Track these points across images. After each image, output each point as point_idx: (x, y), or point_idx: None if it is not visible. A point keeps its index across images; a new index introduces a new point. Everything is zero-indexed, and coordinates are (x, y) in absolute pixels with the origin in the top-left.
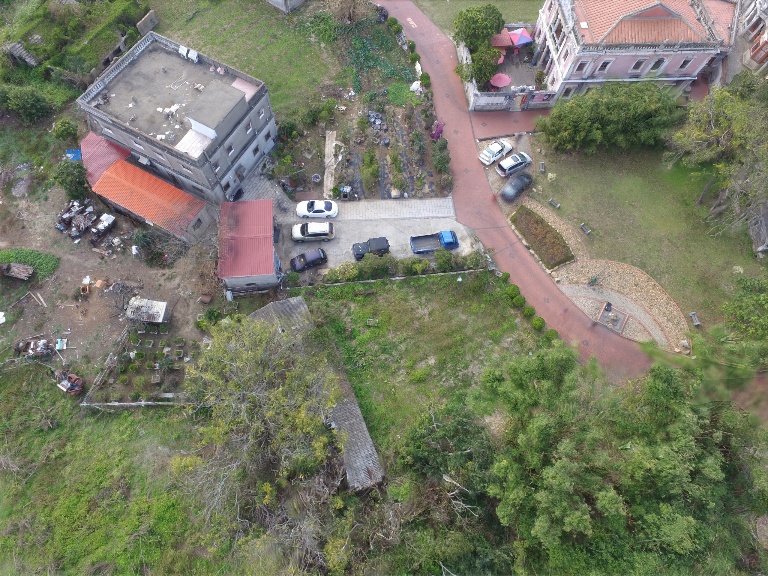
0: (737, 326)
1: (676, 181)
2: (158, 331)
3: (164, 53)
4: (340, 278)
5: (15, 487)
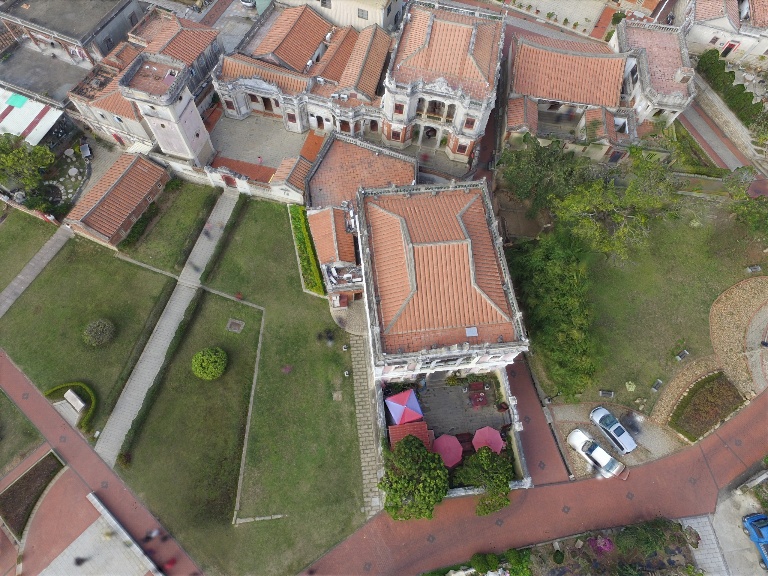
0: None
1: None
2: None
3: None
4: None
5: None
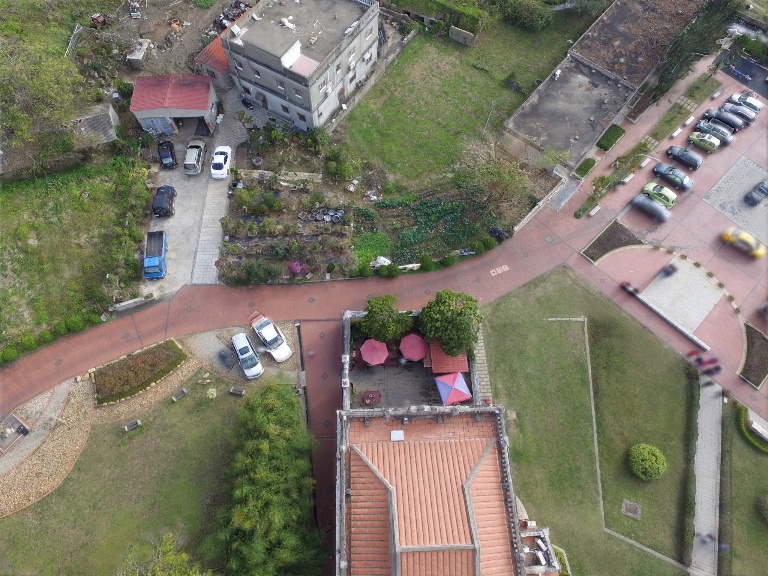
0: None
1: None
2: None
3: (359, 16)
4: None
5: (38, 4)
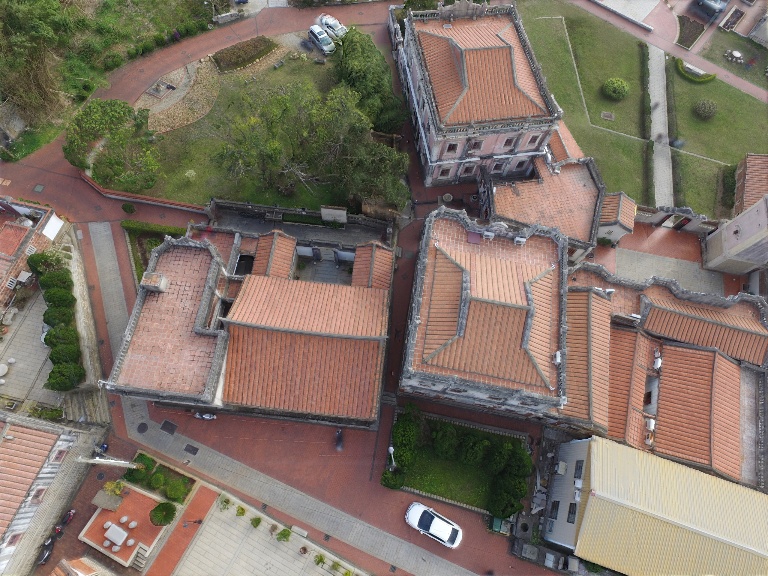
0: None
1: None
2: None
3: None
4: None
5: None
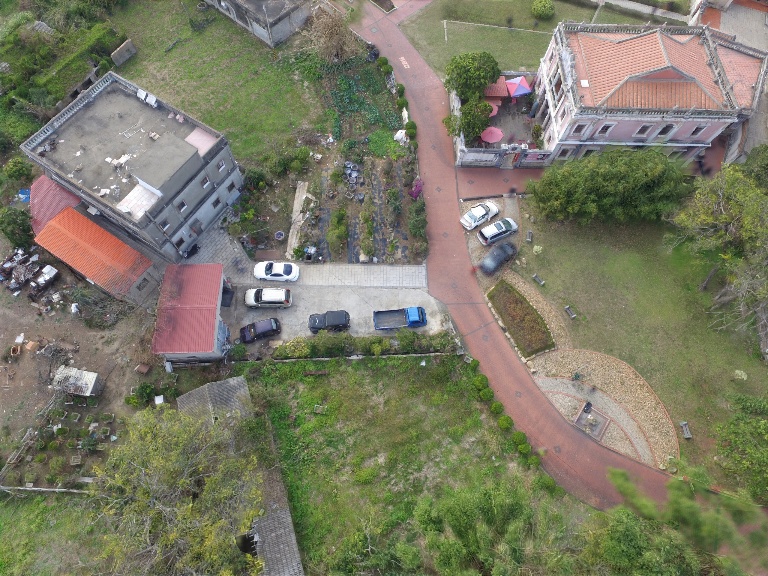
0: (731, 456)
1: (679, 261)
2: (86, 404)
3: (122, 95)
4: (290, 355)
5: None
